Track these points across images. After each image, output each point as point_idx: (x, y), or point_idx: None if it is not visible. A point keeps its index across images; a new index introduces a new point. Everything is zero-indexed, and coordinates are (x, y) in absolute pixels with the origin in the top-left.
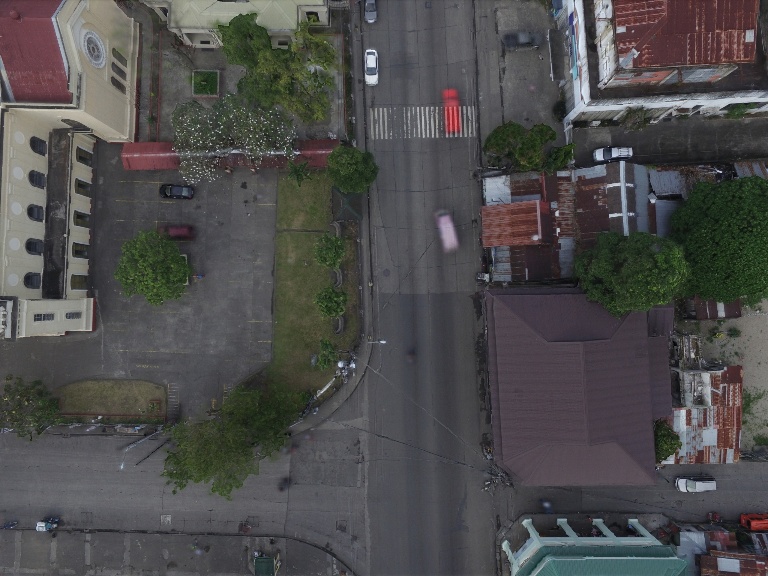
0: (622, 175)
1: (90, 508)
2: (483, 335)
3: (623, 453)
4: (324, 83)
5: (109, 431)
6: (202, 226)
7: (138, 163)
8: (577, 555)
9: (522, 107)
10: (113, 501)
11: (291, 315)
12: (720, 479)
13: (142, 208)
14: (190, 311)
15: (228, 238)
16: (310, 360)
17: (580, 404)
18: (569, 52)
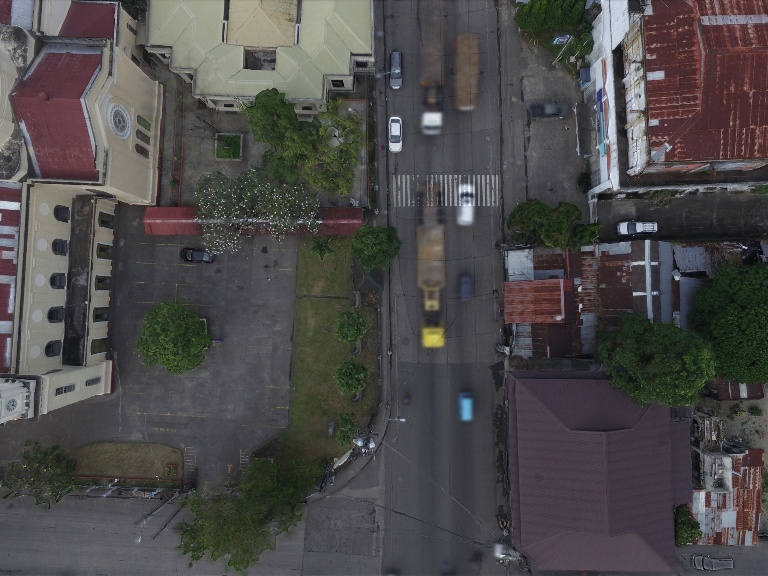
0: (647, 254)
1: (105, 570)
2: (503, 414)
3: (643, 543)
4: (350, 159)
5: (125, 494)
6: (222, 290)
7: (160, 228)
8: None
9: (546, 177)
10: (128, 564)
11: (309, 381)
12: (737, 557)
13: (162, 271)
14: (208, 375)
15: (248, 303)
16: (327, 427)
17: (601, 495)
18: (596, 127)
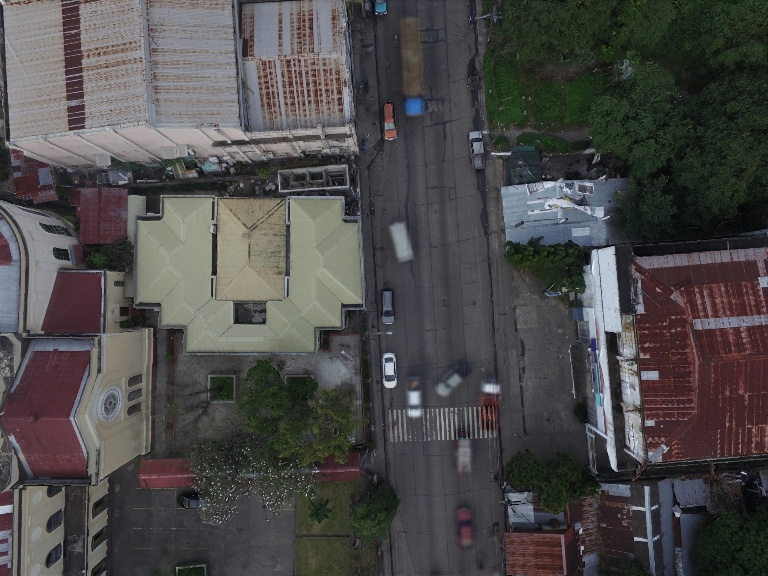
0: (647, 501)
1: None
2: None
3: None
4: None
5: None
6: (220, 533)
7: (155, 483)
8: None
9: (543, 407)
10: None
11: None
12: None
13: (159, 516)
14: None
15: (247, 544)
16: None
17: None
18: (591, 369)
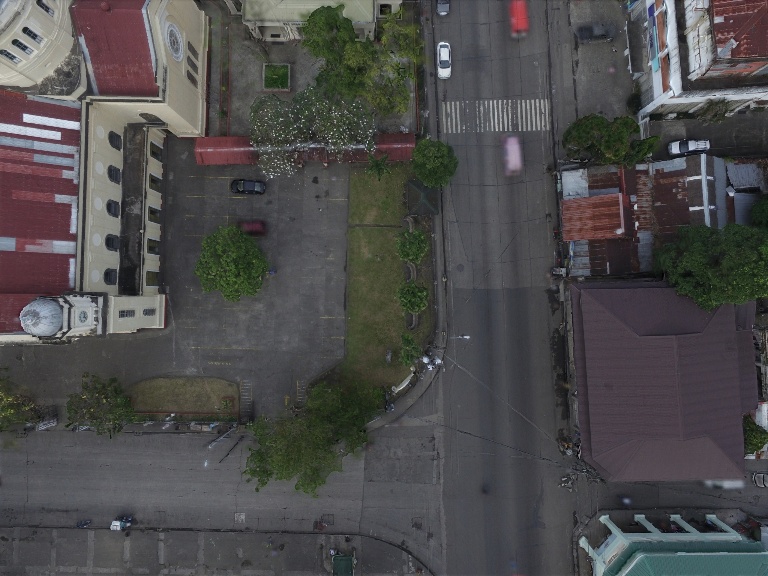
0: (703, 168)
1: (163, 507)
2: (566, 330)
3: (715, 448)
4: (407, 76)
5: (182, 429)
6: (273, 221)
7: (211, 158)
8: (668, 551)
9: (596, 100)
10: (186, 499)
11: (364, 311)
12: None
13: (213, 203)
14: (262, 307)
15: (300, 233)
16: (384, 356)
17: (674, 398)
18: (647, 44)
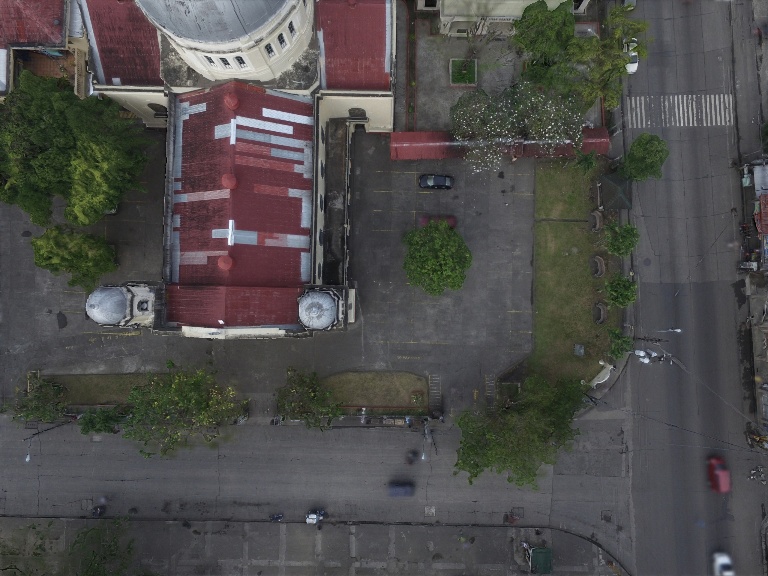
0: None
1: (354, 500)
2: None
3: None
4: None
5: (375, 423)
6: (460, 216)
7: (406, 153)
8: None
9: None
10: (377, 493)
11: (551, 305)
12: None
13: (400, 198)
14: (450, 302)
15: (486, 228)
16: (571, 350)
17: None
18: None
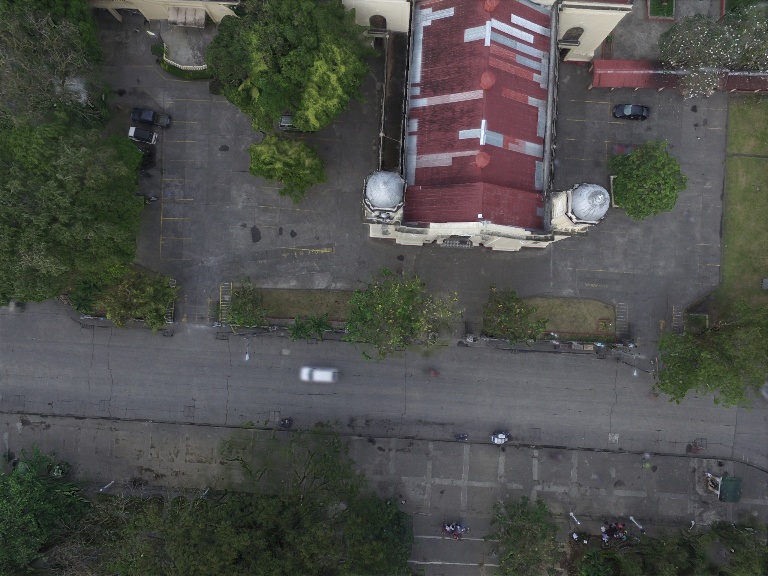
0: None
1: (538, 424)
2: None
3: None
4: None
5: (564, 347)
6: None
7: (609, 80)
8: None
9: None
10: (561, 418)
11: (740, 239)
12: None
13: (593, 128)
14: (639, 232)
15: (678, 161)
16: (758, 285)
17: None
18: None
